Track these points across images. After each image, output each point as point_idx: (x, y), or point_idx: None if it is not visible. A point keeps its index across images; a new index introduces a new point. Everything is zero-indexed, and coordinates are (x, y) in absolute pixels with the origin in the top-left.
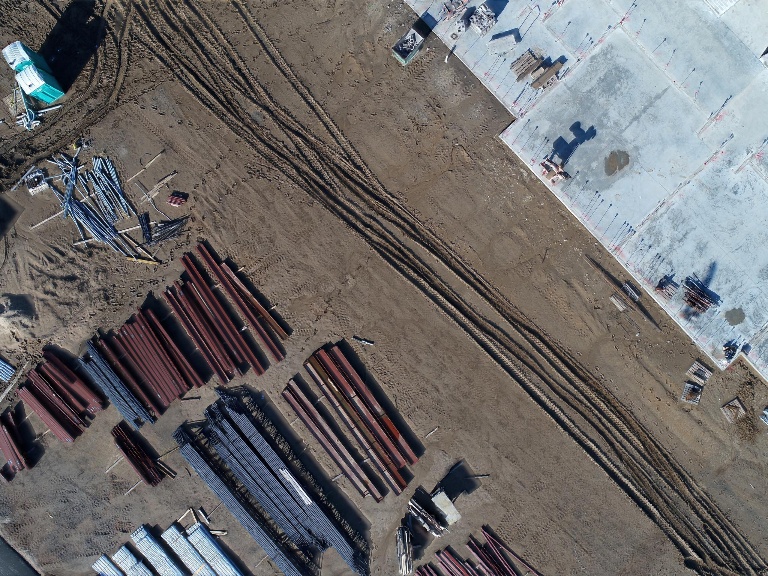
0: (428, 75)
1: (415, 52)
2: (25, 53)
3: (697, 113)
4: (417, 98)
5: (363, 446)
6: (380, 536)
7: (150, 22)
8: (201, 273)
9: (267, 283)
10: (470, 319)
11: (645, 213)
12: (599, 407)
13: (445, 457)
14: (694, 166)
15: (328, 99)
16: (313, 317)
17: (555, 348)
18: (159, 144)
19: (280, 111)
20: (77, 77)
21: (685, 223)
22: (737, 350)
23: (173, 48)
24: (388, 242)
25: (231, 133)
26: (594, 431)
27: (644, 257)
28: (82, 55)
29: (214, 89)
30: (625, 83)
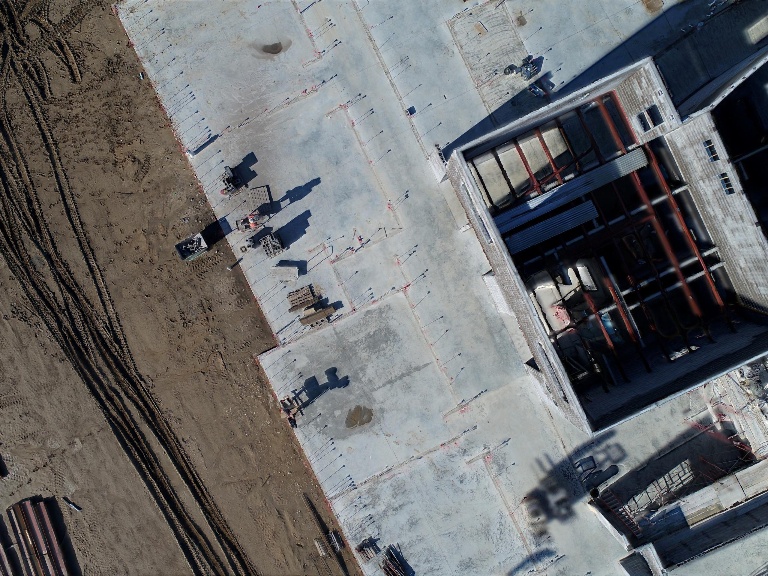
0: (209, 276)
1: (201, 253)
2: None
3: (449, 396)
4: (192, 295)
5: None
6: None
7: None
8: None
9: None
10: (178, 517)
11: (370, 473)
12: None
13: None
14: (431, 444)
15: (109, 267)
16: (31, 467)
17: (249, 569)
18: None
19: (60, 263)
20: None
21: (405, 494)
22: None
23: None
24: (124, 420)
25: (7, 269)
26: None
27: (356, 514)
28: None
29: (4, 222)
30: (391, 346)
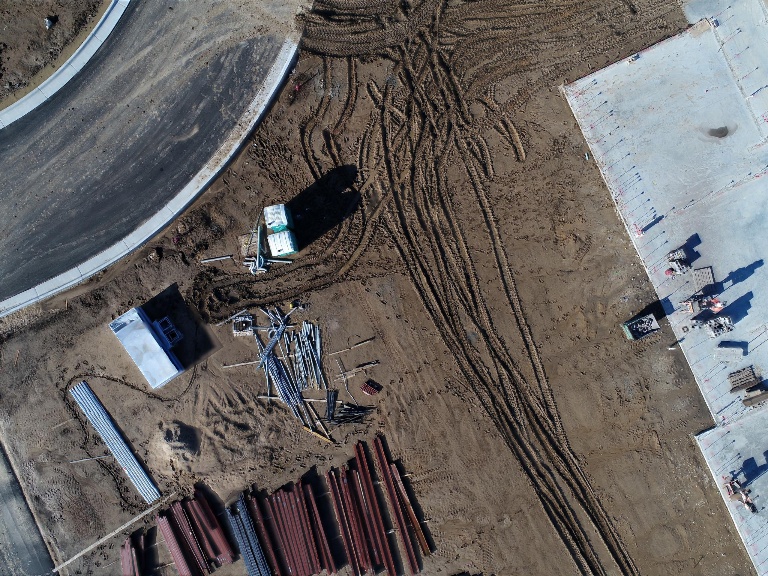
0: (648, 355)
1: None
2: (286, 218)
3: None
4: (630, 373)
5: None
6: None
7: (402, 212)
8: (369, 465)
9: (428, 496)
10: None
11: None
12: None
13: None
14: None
15: (545, 344)
16: (460, 543)
17: None
18: (371, 330)
19: (496, 339)
20: (316, 240)
21: None
22: None
23: (415, 244)
24: (555, 497)
25: (442, 343)
26: None
27: None
28: (327, 221)
29: (441, 296)
30: None
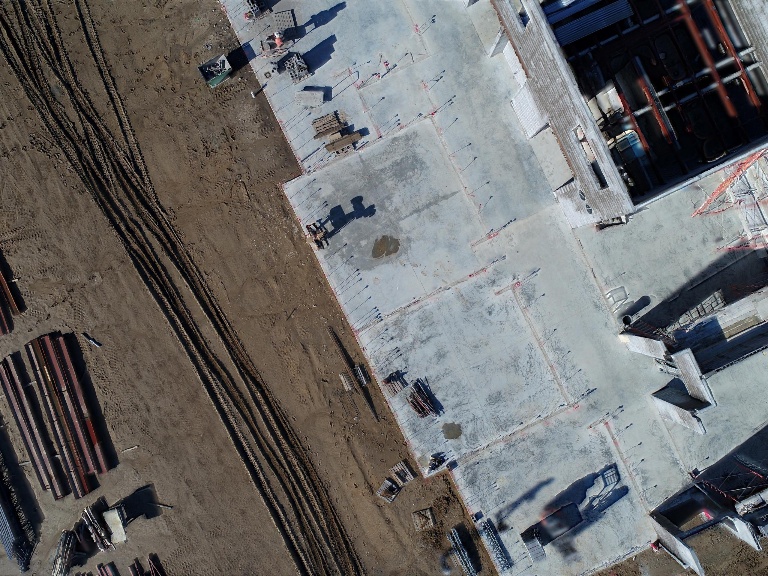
0: (233, 104)
1: (224, 78)
2: None
3: (478, 225)
4: (215, 123)
5: (58, 441)
6: (50, 532)
7: None
8: None
9: (16, 255)
10: (200, 352)
11: (397, 305)
12: (298, 475)
13: (135, 476)
14: (459, 275)
15: (130, 96)
16: (50, 302)
17: (273, 406)
18: None
19: (80, 92)
20: None
21: (432, 326)
22: (443, 463)
23: None
24: (145, 253)
25: (26, 98)
26: (285, 497)
27: (383, 346)
28: None
29: (23, 50)
30: (418, 174)
